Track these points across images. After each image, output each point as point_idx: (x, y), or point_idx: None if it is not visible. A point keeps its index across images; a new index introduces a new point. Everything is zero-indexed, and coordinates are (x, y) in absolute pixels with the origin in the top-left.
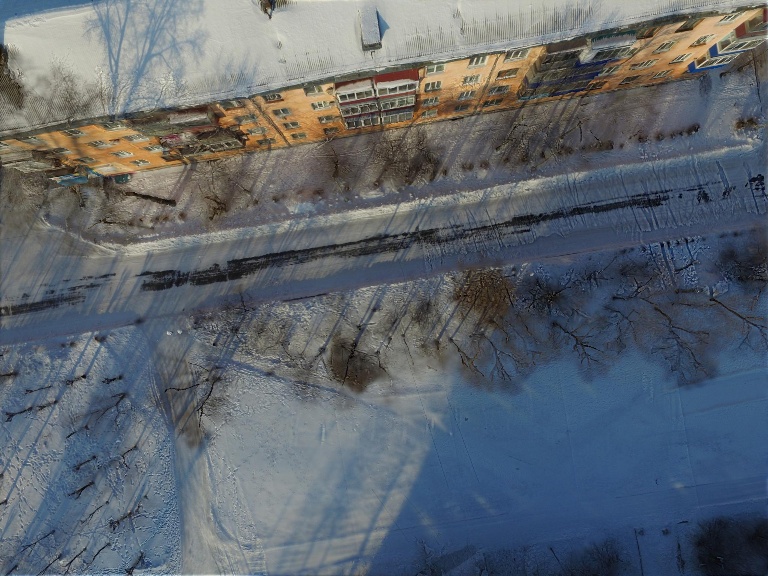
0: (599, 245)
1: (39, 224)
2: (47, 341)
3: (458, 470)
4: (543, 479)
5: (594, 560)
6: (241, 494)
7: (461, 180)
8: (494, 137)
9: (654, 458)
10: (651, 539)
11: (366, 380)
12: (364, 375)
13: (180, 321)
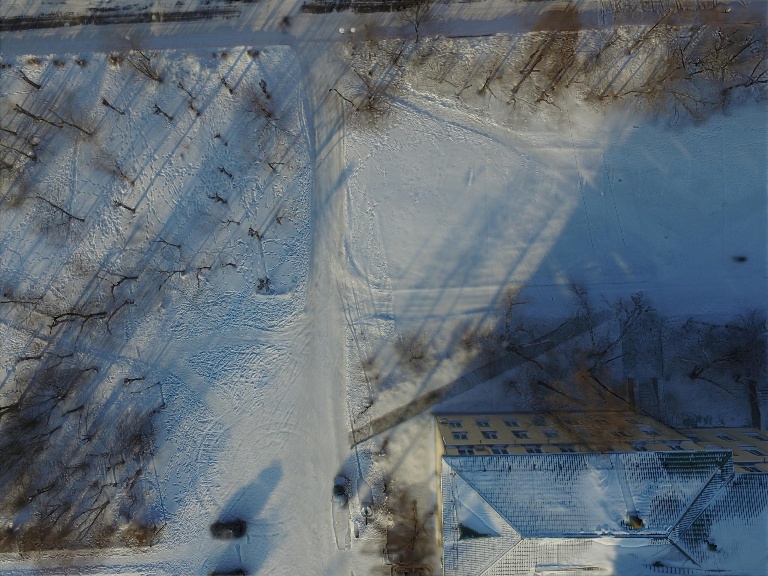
0: None
1: None
2: (197, 50)
3: (605, 231)
4: (691, 251)
5: (739, 330)
6: (377, 231)
7: None
8: None
9: None
10: None
11: (522, 129)
12: (520, 123)
13: (336, 47)
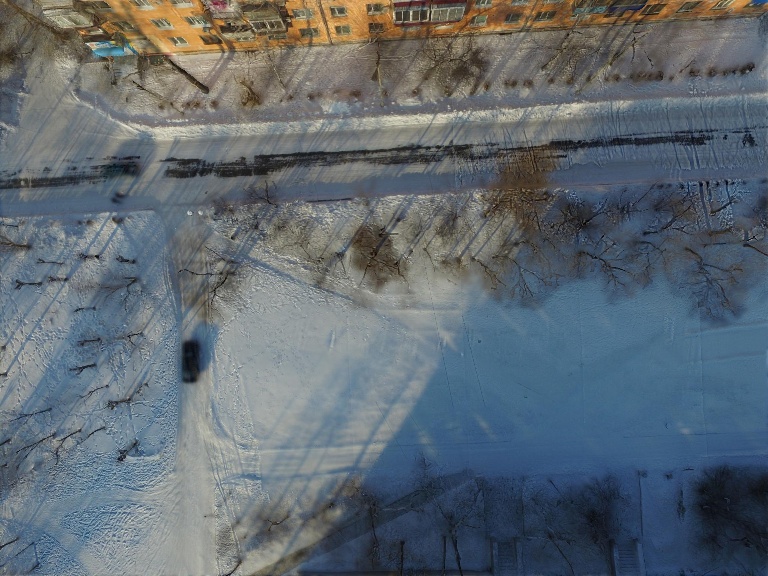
0: (636, 179)
1: (68, 98)
2: (64, 217)
3: (465, 392)
4: (551, 411)
5: (594, 495)
6: (243, 392)
7: (502, 97)
8: (541, 56)
9: (667, 401)
10: (654, 483)
11: (382, 291)
12: (380, 285)
13: None
